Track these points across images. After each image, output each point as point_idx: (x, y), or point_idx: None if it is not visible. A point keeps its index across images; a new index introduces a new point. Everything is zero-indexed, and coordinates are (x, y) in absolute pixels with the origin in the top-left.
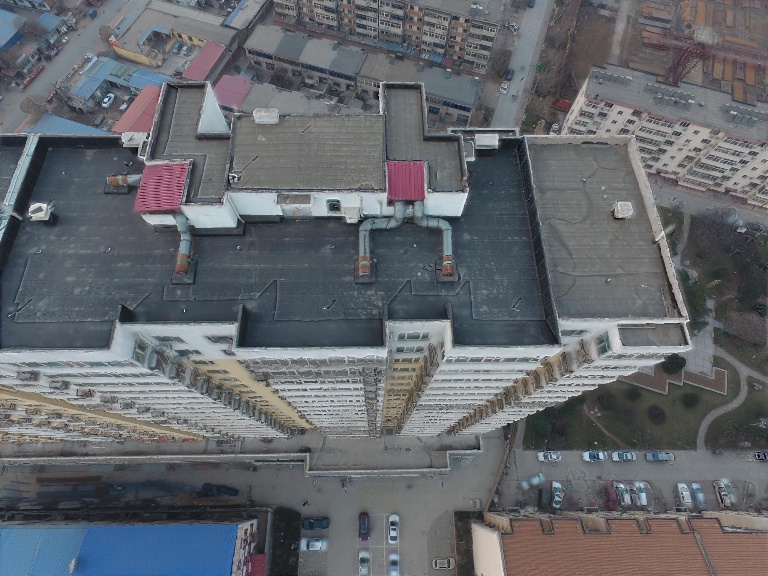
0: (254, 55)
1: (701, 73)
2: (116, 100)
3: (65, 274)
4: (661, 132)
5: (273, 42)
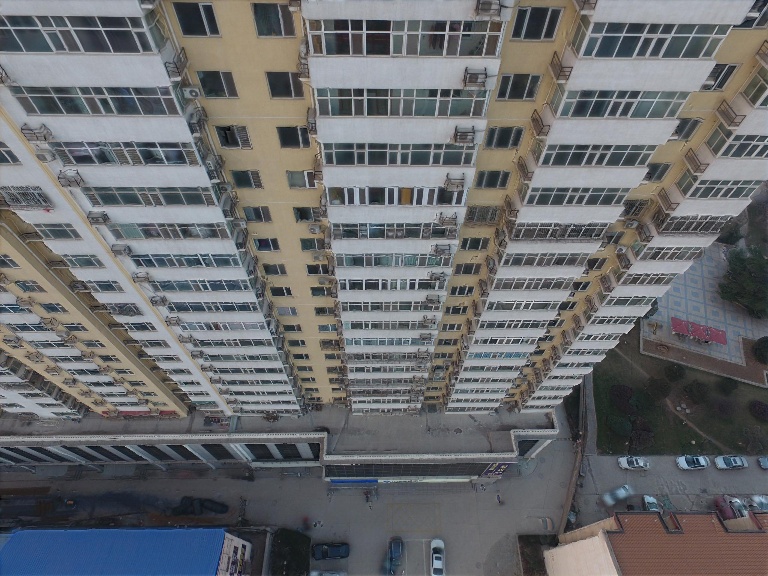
0: None
1: None
2: None
3: None
4: None
5: None
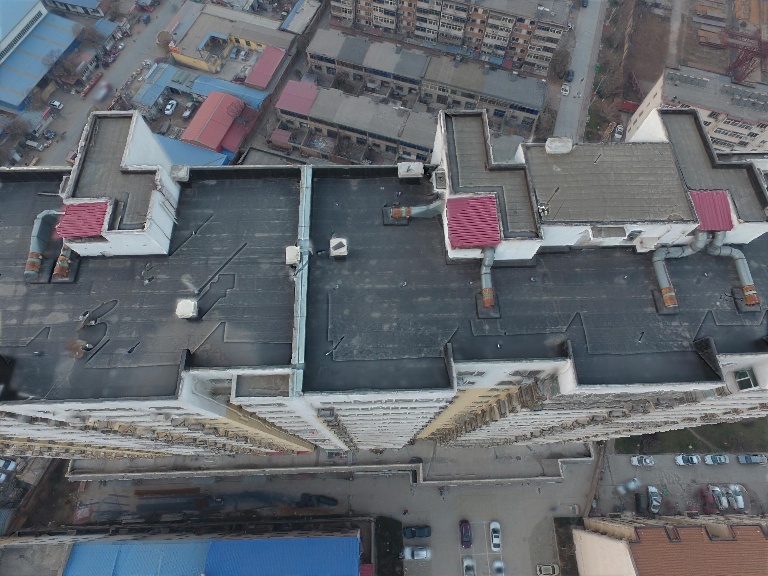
0: (316, 59)
1: (759, 72)
2: (178, 107)
3: (369, 310)
4: (737, 133)
5: (335, 46)
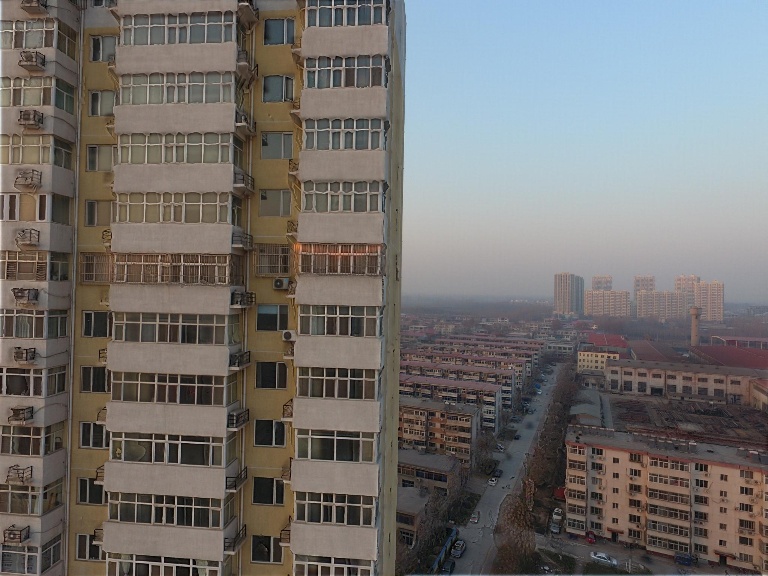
0: None
1: None
2: None
3: None
4: (678, 479)
5: None
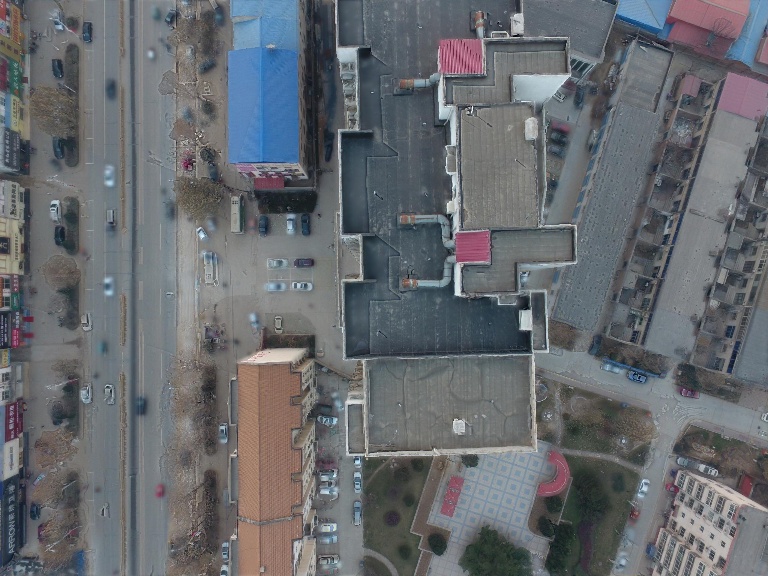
0: None
1: None
2: None
3: (400, 1)
4: None
5: None
